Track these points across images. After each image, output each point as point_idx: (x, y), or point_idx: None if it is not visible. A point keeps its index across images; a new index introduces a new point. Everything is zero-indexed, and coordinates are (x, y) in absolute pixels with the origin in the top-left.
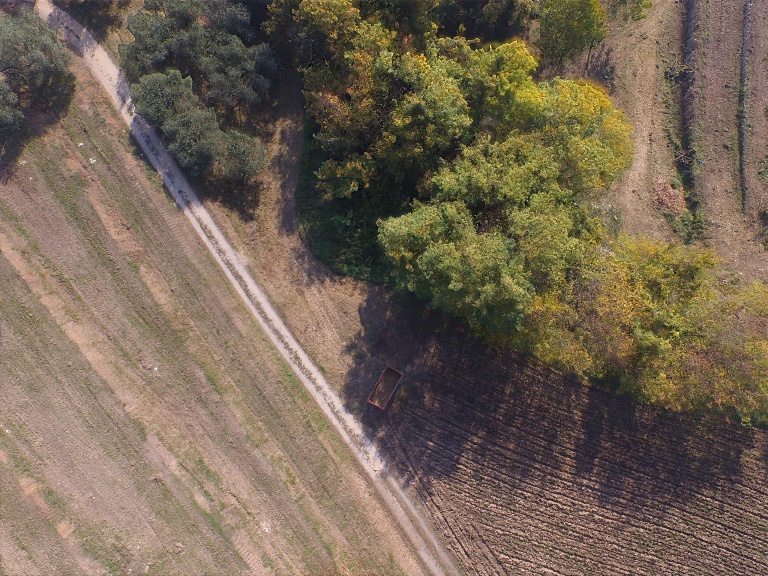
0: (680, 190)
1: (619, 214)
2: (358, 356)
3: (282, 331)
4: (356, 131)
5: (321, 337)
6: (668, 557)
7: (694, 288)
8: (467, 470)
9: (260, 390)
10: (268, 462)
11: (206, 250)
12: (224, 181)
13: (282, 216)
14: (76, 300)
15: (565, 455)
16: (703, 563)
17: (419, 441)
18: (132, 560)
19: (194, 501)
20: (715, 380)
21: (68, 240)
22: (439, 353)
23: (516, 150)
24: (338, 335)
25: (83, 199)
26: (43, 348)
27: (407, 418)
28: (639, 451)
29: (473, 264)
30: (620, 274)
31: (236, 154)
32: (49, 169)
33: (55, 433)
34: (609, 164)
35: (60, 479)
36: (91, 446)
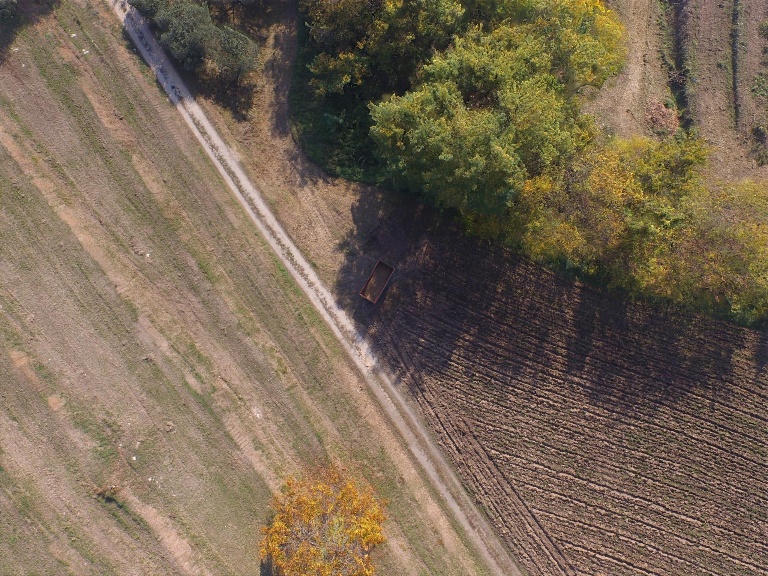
0: (674, 109)
1: (613, 132)
2: (350, 253)
3: (274, 227)
4: (349, 23)
5: (313, 235)
6: (659, 454)
7: (685, 180)
8: (459, 367)
9: (252, 281)
10: (260, 350)
11: (199, 145)
12: (217, 81)
13: (275, 119)
14: (68, 185)
15: (556, 353)
16: (693, 460)
17: (411, 337)
18: (123, 436)
19: (185, 382)
20: (705, 262)
21: (60, 127)
22: (431, 251)
23: (508, 39)
24: (330, 234)
25: (76, 87)
26: (35, 228)
27: (399, 315)
28: (630, 350)
29: (463, 132)
30: (611, 165)
31: (229, 48)
32: (42, 57)
33: (46, 310)
34: (601, 58)
35: (51, 355)
36: (82, 324)
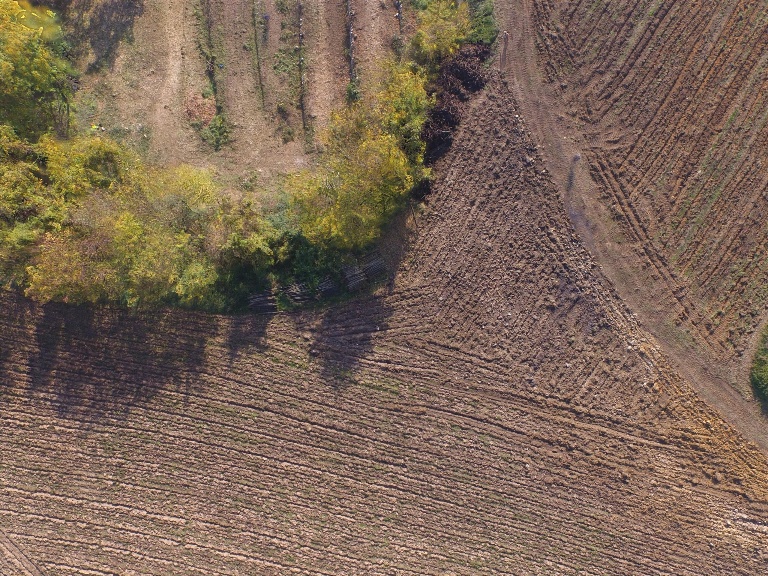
0: (210, 98)
1: (149, 131)
2: None
3: None
4: None
5: None
6: (136, 458)
7: None
8: None
9: None
10: None
11: None
12: None
13: None
14: None
15: (19, 371)
16: (172, 458)
17: None
18: None
19: None
20: None
21: None
22: None
23: None
24: None
25: None
26: None
27: None
28: (99, 356)
29: None
30: None
31: None
32: None
33: None
34: None
35: None
36: None
